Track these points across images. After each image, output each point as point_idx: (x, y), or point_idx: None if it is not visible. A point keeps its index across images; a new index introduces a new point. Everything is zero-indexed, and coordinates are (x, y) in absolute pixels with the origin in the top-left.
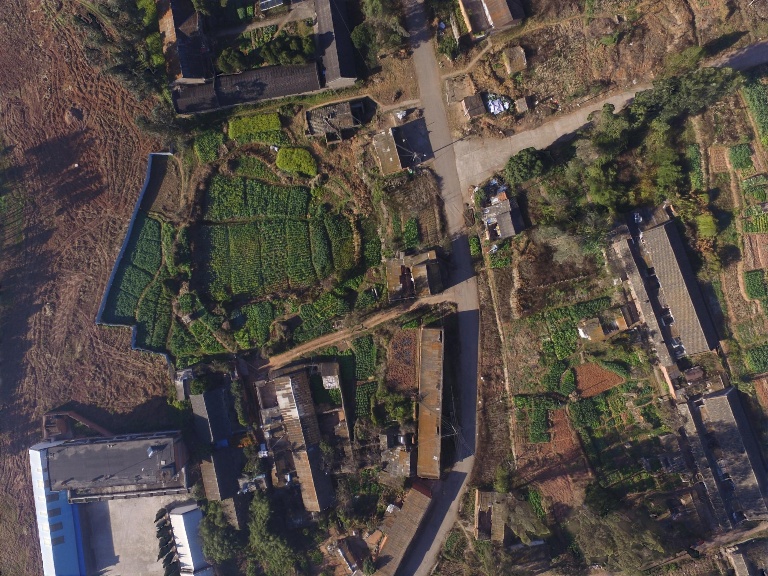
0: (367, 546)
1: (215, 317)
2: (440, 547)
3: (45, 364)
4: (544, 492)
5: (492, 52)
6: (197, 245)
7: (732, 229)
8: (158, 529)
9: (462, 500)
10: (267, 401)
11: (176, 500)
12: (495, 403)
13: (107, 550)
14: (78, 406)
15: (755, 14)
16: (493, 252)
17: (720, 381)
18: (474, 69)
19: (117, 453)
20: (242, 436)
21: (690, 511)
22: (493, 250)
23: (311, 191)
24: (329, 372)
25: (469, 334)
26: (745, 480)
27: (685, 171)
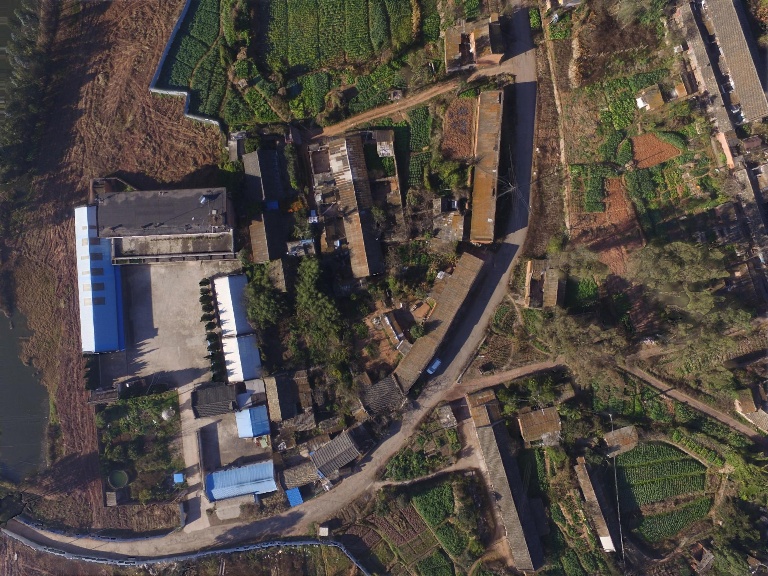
0: (414, 319)
1: (271, 83)
2: (489, 321)
3: (95, 133)
4: None
5: None
6: (256, 15)
7: None
8: (201, 295)
9: (513, 272)
10: (319, 171)
11: (220, 272)
12: (550, 175)
13: (146, 322)
14: (126, 174)
15: None
16: (553, 23)
17: None
18: None
19: (168, 201)
20: (293, 200)
21: (745, 282)
22: (554, 20)
23: None
24: (384, 138)
25: (526, 106)
26: None
27: None
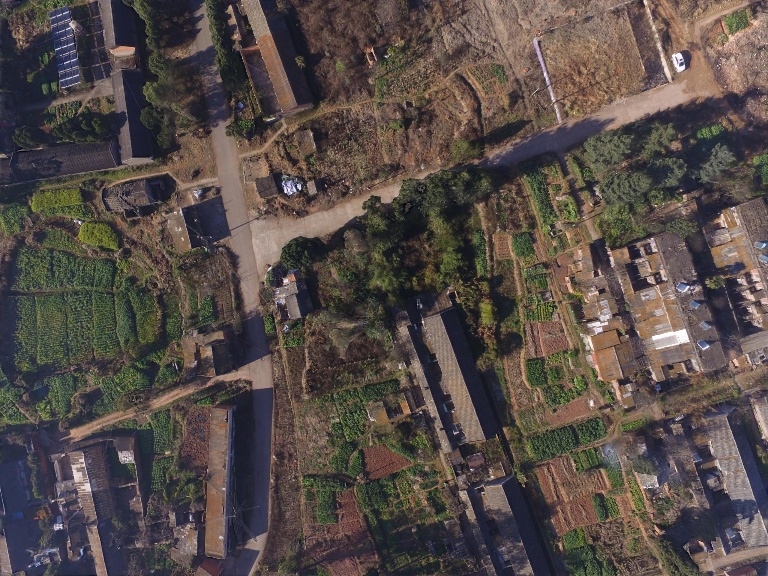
0: None
1: (16, 388)
2: None
3: None
4: (332, 573)
5: (286, 133)
6: (2, 316)
7: (515, 316)
8: None
9: None
10: (67, 473)
11: None
12: (288, 482)
13: None
14: None
15: (538, 104)
16: (285, 332)
17: (501, 468)
18: (270, 149)
19: None
20: (38, 508)
21: None
22: (284, 330)
23: (117, 264)
24: (124, 447)
25: (263, 412)
26: (523, 569)
27: (470, 257)
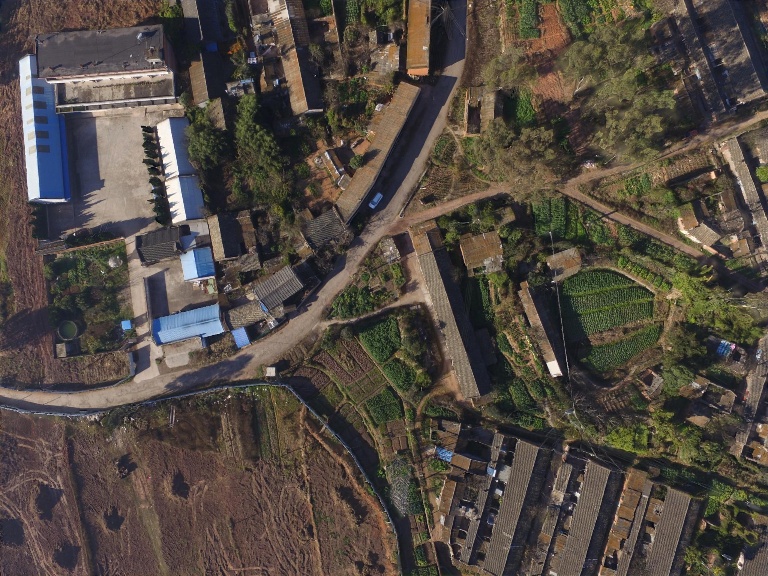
0: None
1: None
2: (429, 153)
3: None
4: (534, 90)
5: None
6: None
7: None
8: (144, 140)
9: (452, 104)
10: None
11: None
12: (485, 8)
13: (92, 174)
14: (70, 30)
15: None
16: None
17: None
18: None
19: (106, 40)
20: (232, 42)
21: (682, 97)
22: None
23: None
24: None
25: None
26: (737, 57)
27: None
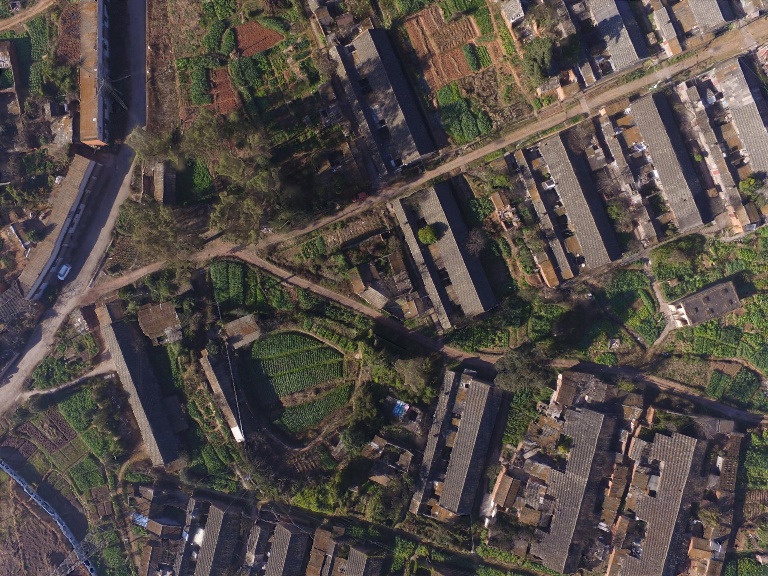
0: None
1: None
2: (114, 223)
3: None
4: (210, 156)
5: None
6: None
7: None
8: None
9: (134, 172)
10: None
11: None
12: (164, 73)
13: None
14: None
15: None
16: None
17: (370, 24)
18: None
19: None
20: None
21: (348, 160)
22: None
23: None
24: None
25: (137, 5)
26: (395, 119)
27: None
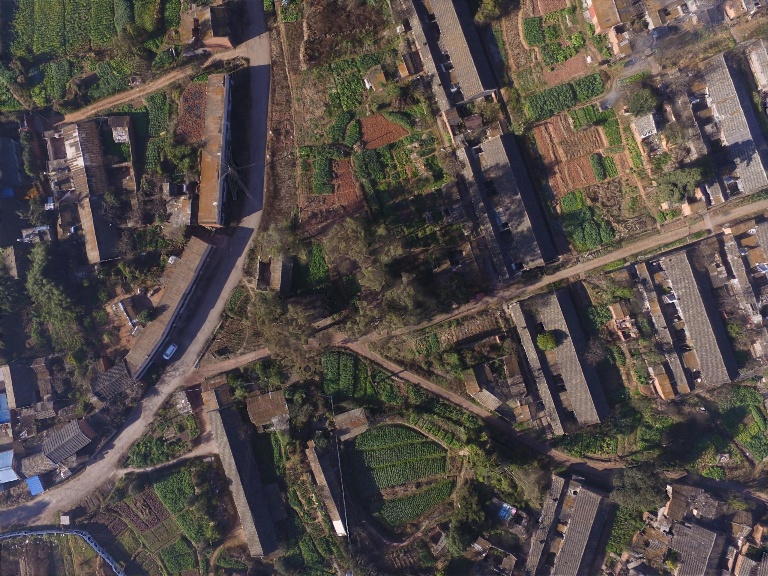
0: (152, 305)
1: (11, 71)
2: (224, 305)
3: None
4: None
5: None
6: None
7: None
8: None
9: (247, 256)
10: (60, 158)
11: None
12: (284, 158)
13: None
14: None
15: None
16: (284, 6)
17: (499, 128)
18: None
19: None
20: (29, 187)
21: (469, 261)
22: (283, 2)
23: None
24: (118, 124)
25: (260, 89)
26: (520, 225)
27: None
